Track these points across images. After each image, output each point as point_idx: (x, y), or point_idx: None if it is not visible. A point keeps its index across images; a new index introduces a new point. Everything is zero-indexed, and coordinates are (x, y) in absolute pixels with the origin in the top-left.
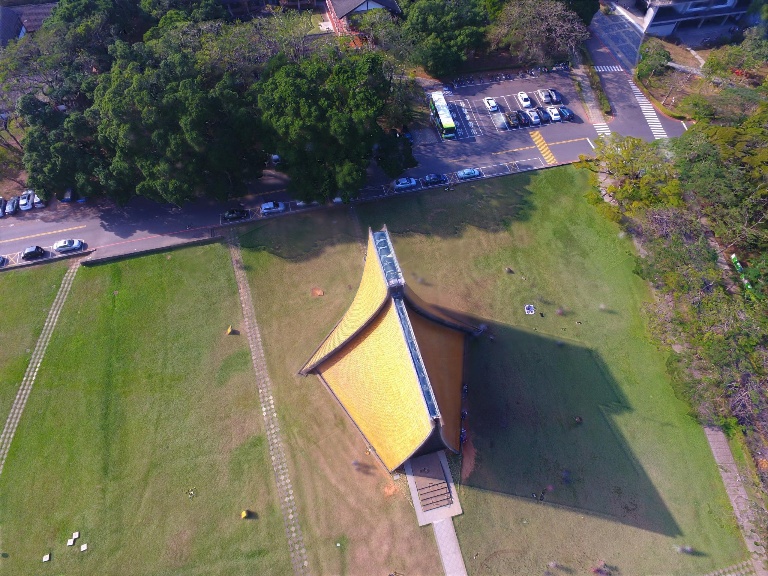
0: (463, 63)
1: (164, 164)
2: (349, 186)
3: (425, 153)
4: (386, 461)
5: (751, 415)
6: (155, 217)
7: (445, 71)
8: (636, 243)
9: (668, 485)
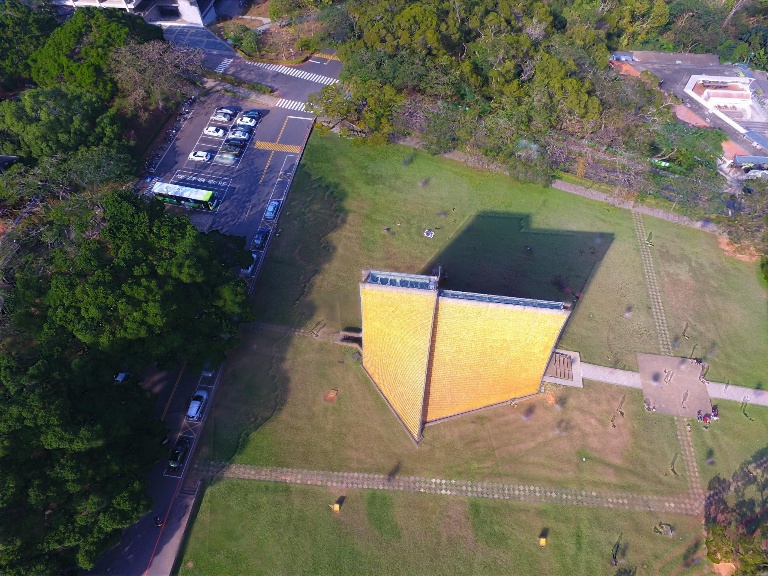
0: (135, 148)
1: (86, 502)
2: (242, 305)
3: (221, 232)
4: (529, 391)
5: (568, 153)
6: (108, 572)
7: (135, 166)
8: (404, 143)
9: (583, 224)
